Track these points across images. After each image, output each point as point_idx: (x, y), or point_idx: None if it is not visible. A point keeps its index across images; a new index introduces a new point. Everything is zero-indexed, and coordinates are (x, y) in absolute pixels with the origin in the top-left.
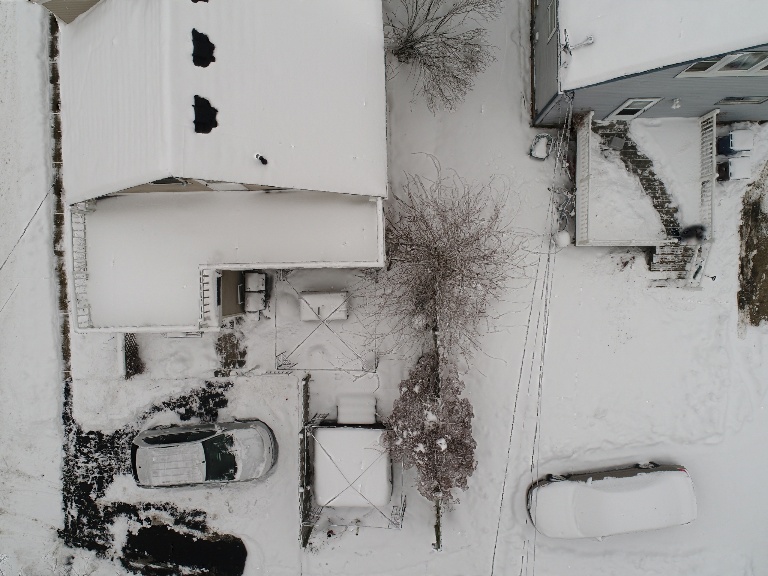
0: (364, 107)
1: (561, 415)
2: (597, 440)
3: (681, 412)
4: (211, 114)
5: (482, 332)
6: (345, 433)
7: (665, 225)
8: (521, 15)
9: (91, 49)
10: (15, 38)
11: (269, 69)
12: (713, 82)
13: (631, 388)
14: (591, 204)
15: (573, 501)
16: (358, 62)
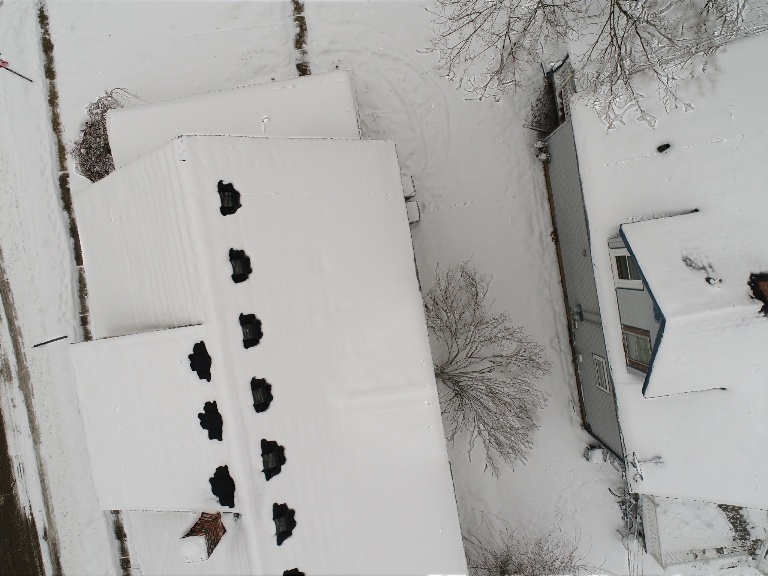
0: (441, 534)
1: None
2: None
3: None
4: None
5: None
6: None
7: (732, 523)
8: (557, 321)
9: (168, 536)
10: (54, 394)
11: (354, 559)
12: None
13: None
14: None
15: None
16: (429, 494)
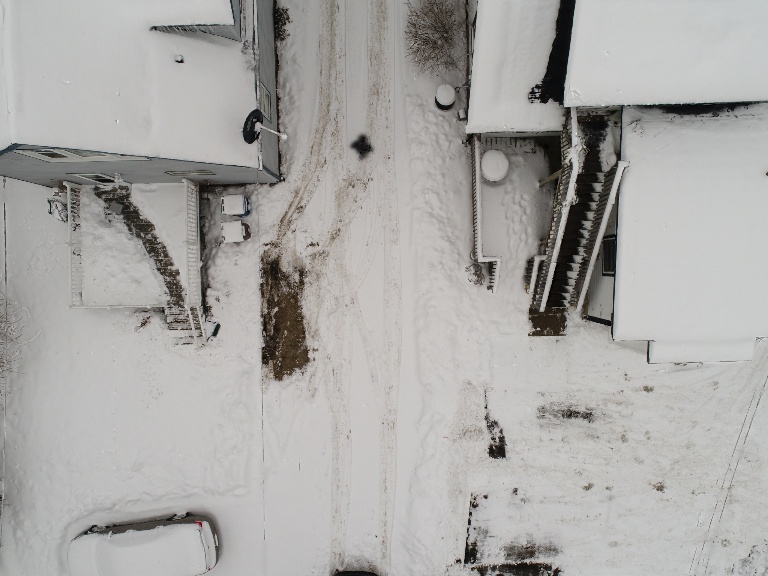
0: None
1: (101, 468)
2: (136, 492)
3: (210, 465)
4: None
5: (25, 388)
6: None
7: (168, 287)
8: None
9: None
10: None
11: None
12: (105, 164)
13: (167, 441)
14: (90, 268)
15: (96, 554)
16: None
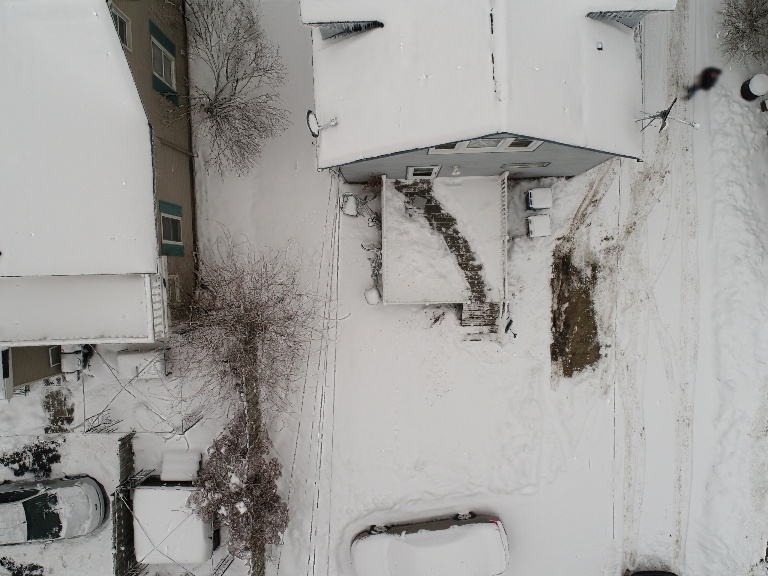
0: (123, 186)
1: (382, 467)
2: (418, 491)
3: (497, 463)
4: None
5: None
6: (161, 492)
7: (470, 282)
8: None
9: None
10: None
11: (1, 160)
12: (473, 156)
13: (450, 440)
14: (394, 264)
15: (388, 554)
16: (115, 142)
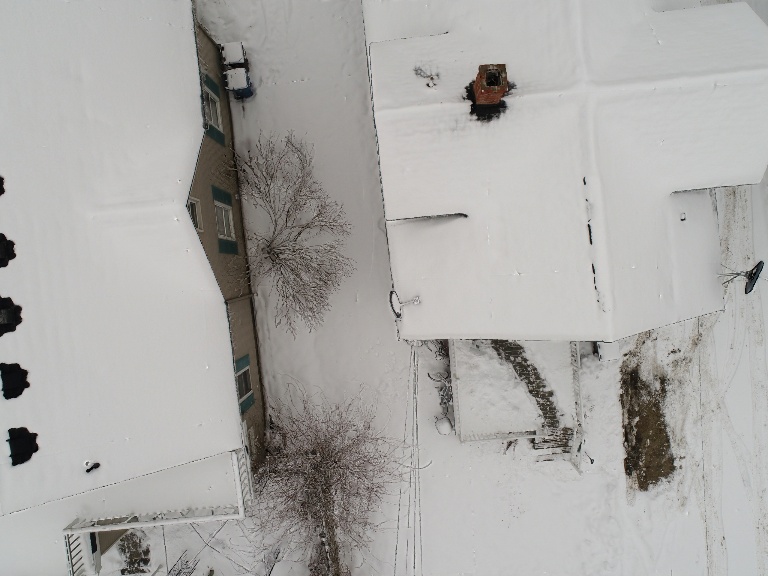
0: (207, 370)
1: None
2: None
3: None
4: (30, 439)
5: (378, 515)
6: None
7: (542, 409)
8: None
9: None
10: None
11: (93, 371)
12: None
13: (529, 559)
14: (465, 398)
15: None
16: (195, 328)
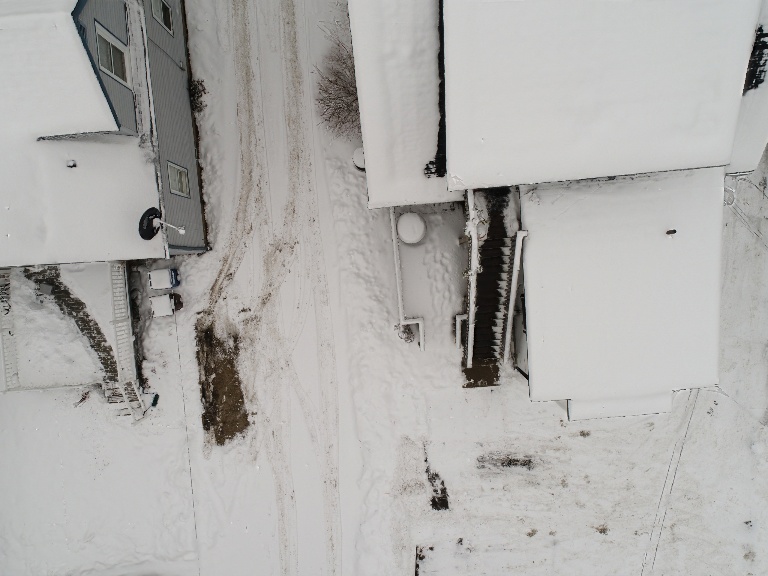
0: None
1: (54, 541)
2: (90, 562)
3: (159, 532)
4: None
5: None
6: None
7: (103, 363)
8: None
9: None
10: None
11: None
12: None
13: (116, 511)
14: (24, 350)
15: None
16: None
